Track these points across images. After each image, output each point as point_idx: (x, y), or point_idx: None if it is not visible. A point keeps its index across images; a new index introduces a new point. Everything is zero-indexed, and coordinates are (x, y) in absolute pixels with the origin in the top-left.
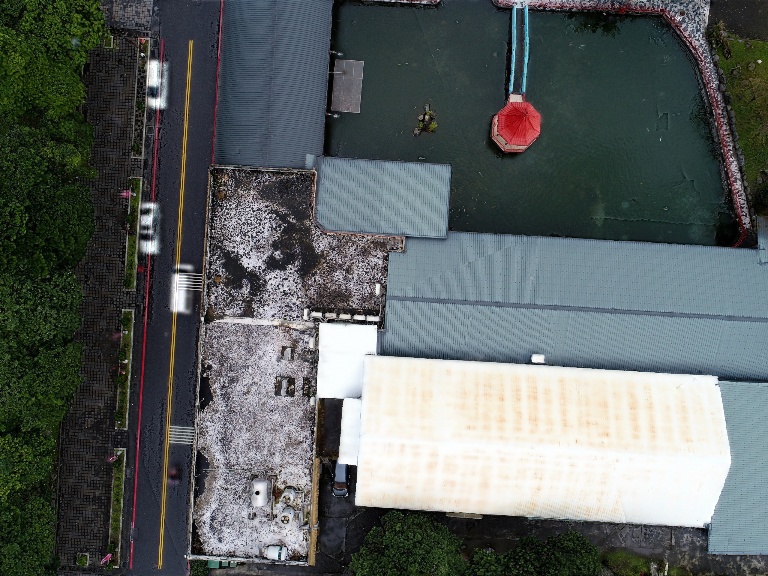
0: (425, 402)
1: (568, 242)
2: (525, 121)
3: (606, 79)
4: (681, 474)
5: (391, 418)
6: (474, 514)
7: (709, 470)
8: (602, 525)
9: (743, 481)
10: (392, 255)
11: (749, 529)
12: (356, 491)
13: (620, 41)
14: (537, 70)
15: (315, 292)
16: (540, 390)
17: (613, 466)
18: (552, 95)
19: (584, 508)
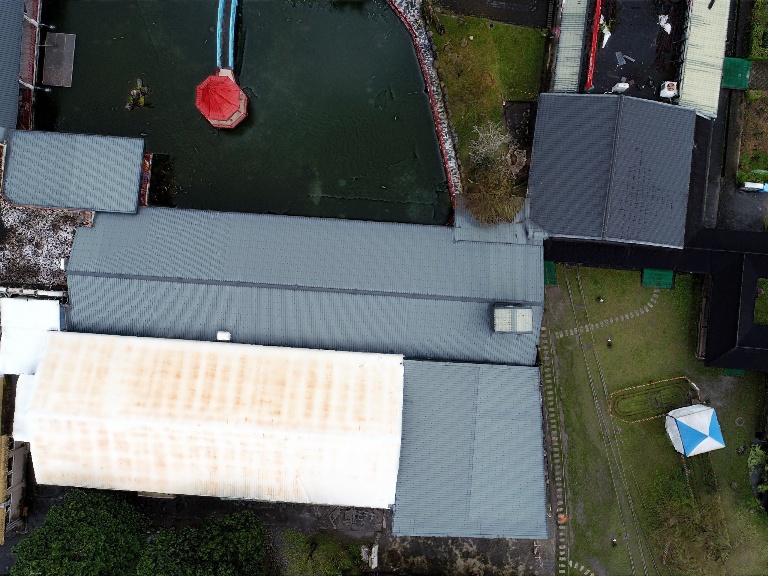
0: (99, 378)
1: (261, 218)
2: (212, 94)
3: (324, 55)
4: (353, 453)
5: (60, 394)
6: (165, 494)
7: (380, 449)
8: (313, 507)
9: (430, 462)
10: (79, 230)
11: (436, 510)
12: (34, 469)
13: (338, 16)
14: (254, 45)
15: (4, 267)
16: (219, 367)
17: (284, 444)
18: (269, 71)
19: (265, 488)
